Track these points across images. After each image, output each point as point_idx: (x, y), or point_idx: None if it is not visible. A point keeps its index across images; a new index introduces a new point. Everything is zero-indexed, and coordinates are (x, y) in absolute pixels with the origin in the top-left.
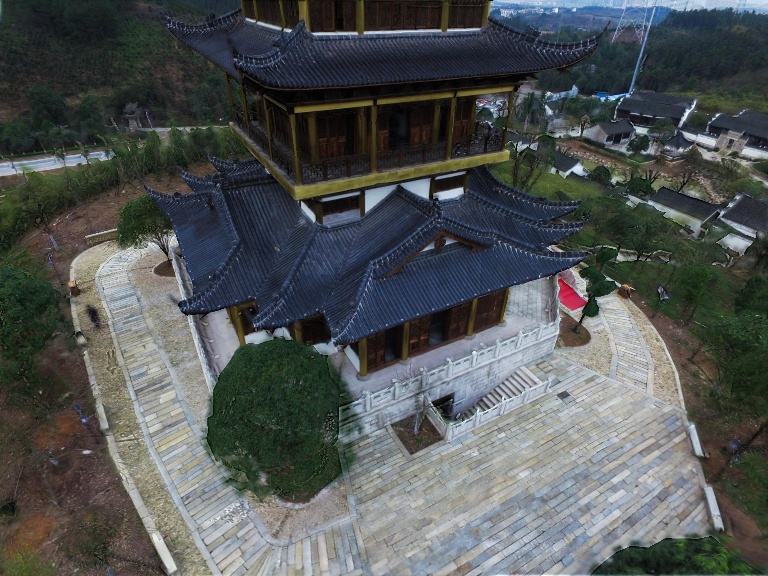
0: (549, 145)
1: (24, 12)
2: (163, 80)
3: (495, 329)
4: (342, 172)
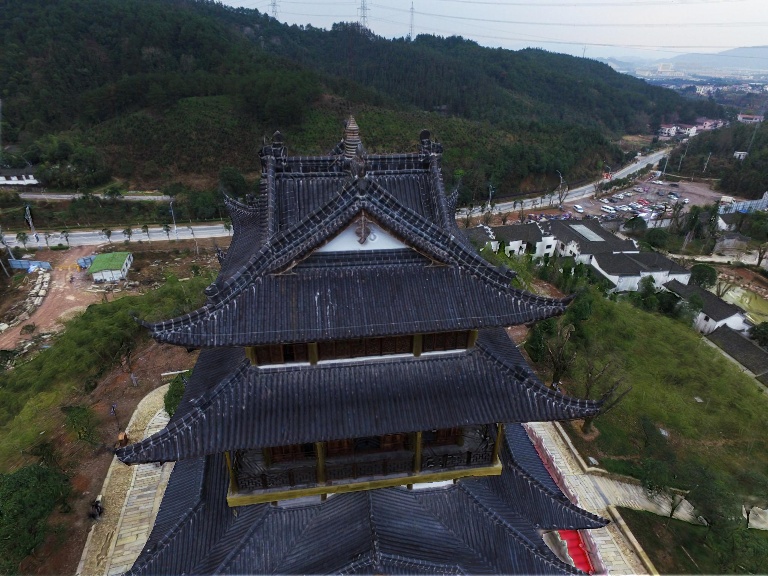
0: (707, 277)
1: (240, 101)
2: None
3: None
4: (284, 482)
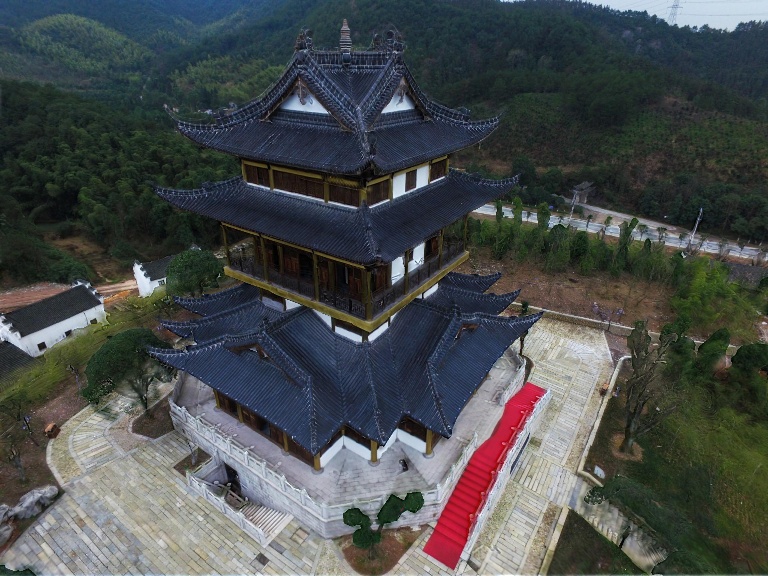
0: None
1: (571, 99)
2: (634, 168)
3: (306, 467)
4: None
